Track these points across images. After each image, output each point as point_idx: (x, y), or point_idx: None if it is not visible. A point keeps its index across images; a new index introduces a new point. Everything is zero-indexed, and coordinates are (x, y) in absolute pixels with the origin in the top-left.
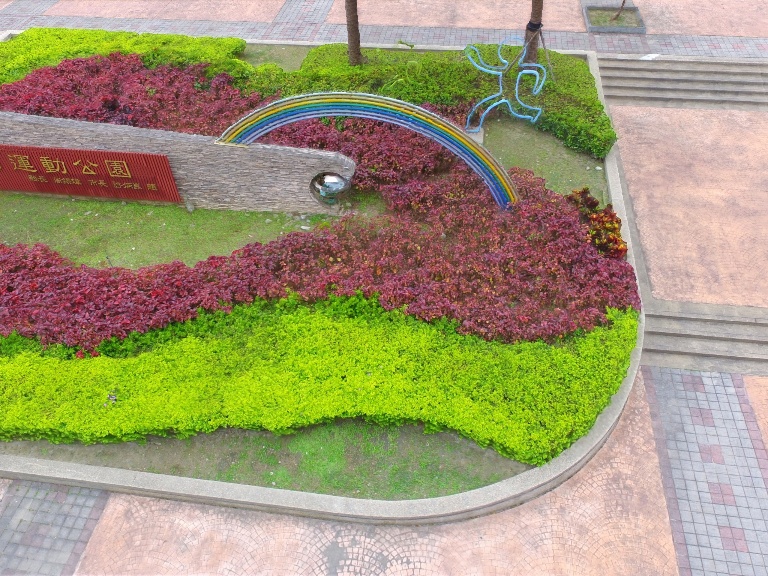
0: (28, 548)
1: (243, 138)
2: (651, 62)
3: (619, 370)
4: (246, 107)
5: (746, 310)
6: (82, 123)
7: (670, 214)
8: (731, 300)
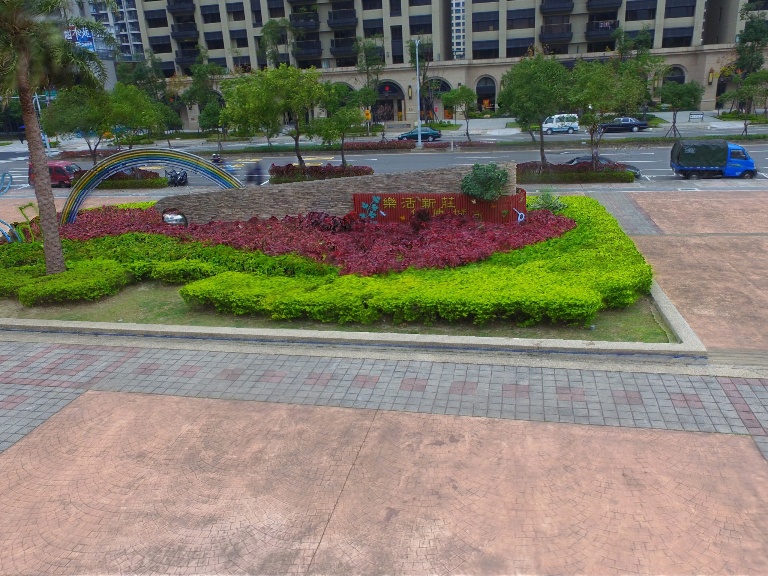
0: None
1: None
2: None
3: None
4: None
5: None
6: None
7: None
8: None
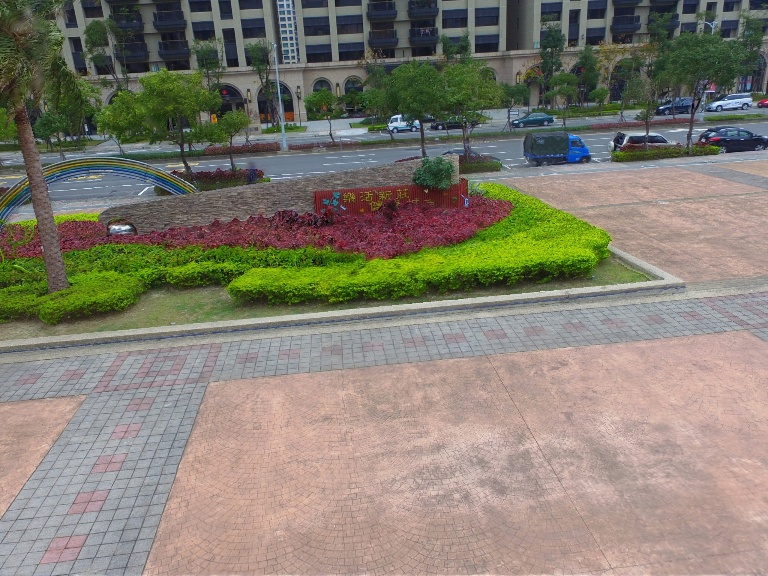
0: None
1: None
2: None
3: None
4: None
5: None
6: None
7: None
8: None
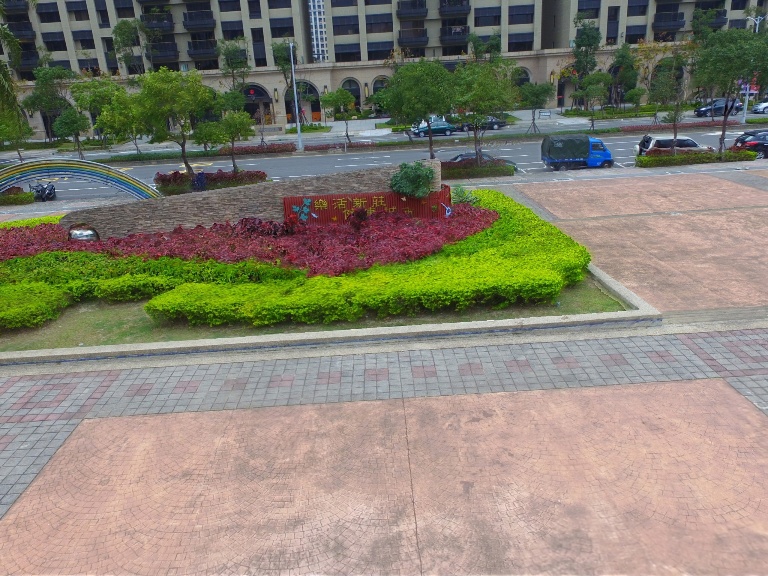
0: None
1: None
2: None
3: None
4: None
5: None
6: None
7: None
8: None
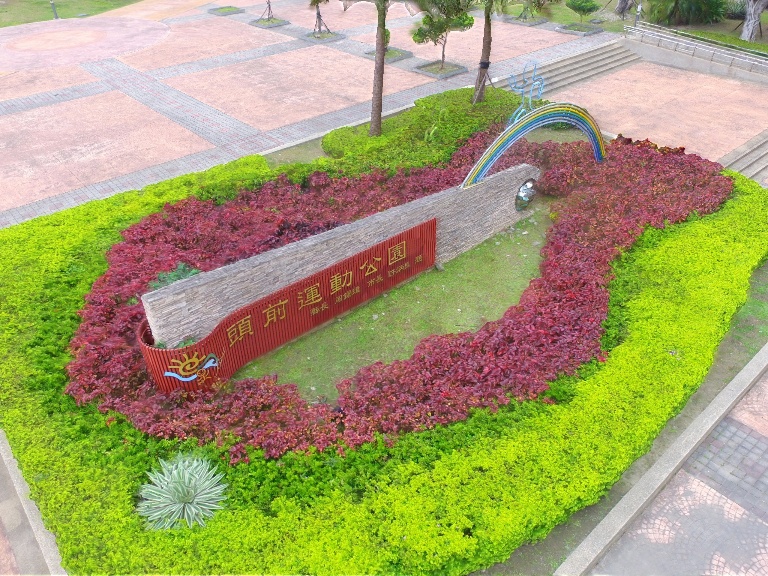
0: (765, 476)
1: (478, 176)
2: (499, 82)
3: (767, 190)
4: None
5: (728, 157)
6: (360, 222)
7: (634, 140)
8: (717, 157)
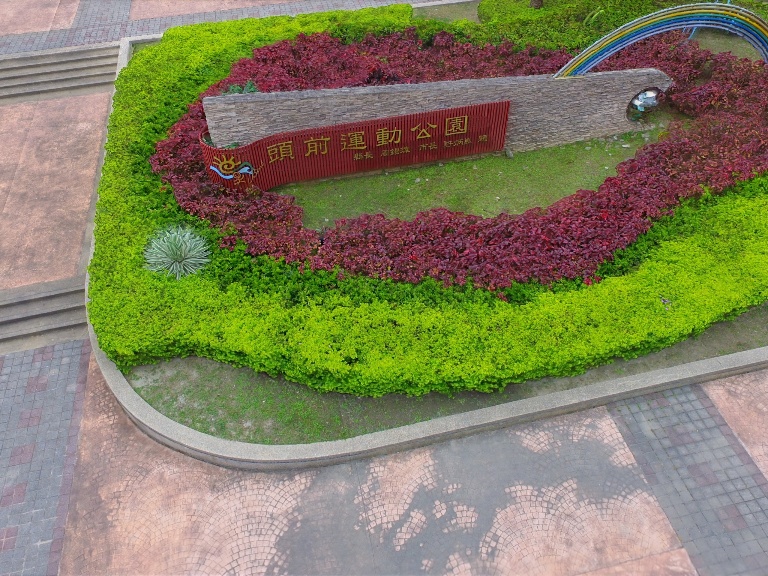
0: (686, 446)
1: (580, 69)
2: None
3: None
4: (492, 57)
5: None
6: (422, 85)
7: None
8: None
